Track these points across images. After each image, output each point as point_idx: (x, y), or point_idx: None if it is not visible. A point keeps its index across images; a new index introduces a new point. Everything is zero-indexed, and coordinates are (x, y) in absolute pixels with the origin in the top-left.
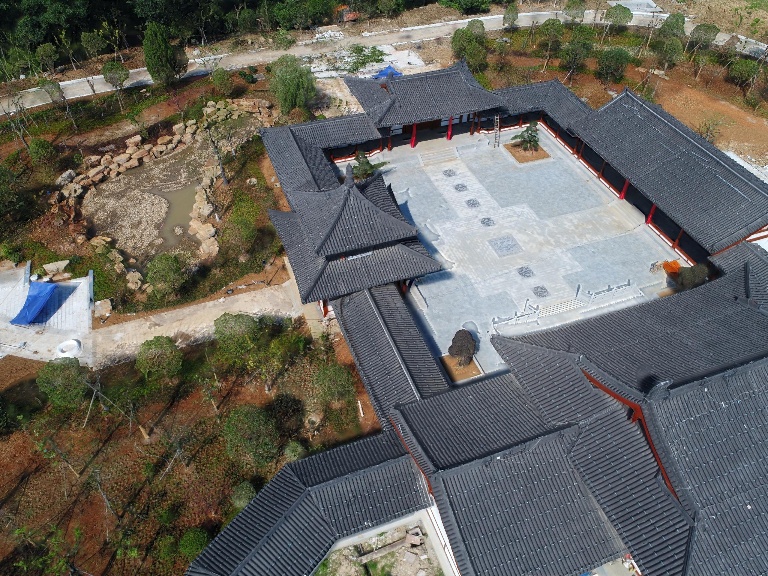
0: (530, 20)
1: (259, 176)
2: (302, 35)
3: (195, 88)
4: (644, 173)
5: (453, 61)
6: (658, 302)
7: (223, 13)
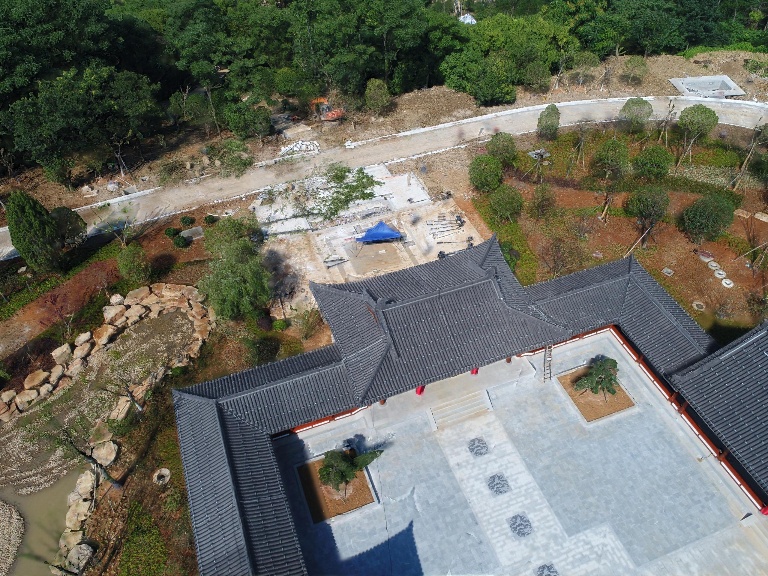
0: (571, 114)
1: (174, 465)
2: (262, 149)
3: (99, 263)
4: None
5: (471, 195)
6: None
7: (160, 108)
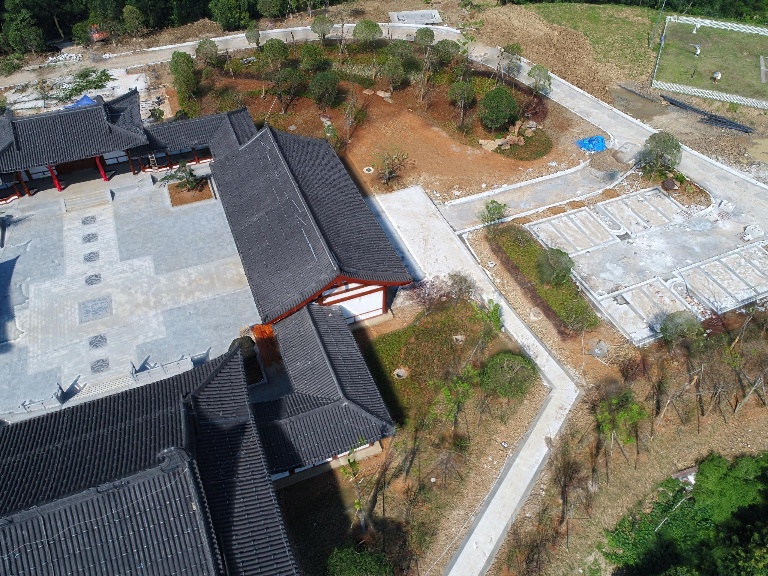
0: None
1: None
2: (35, 59)
3: None
4: (247, 224)
5: None
6: (107, 399)
7: None
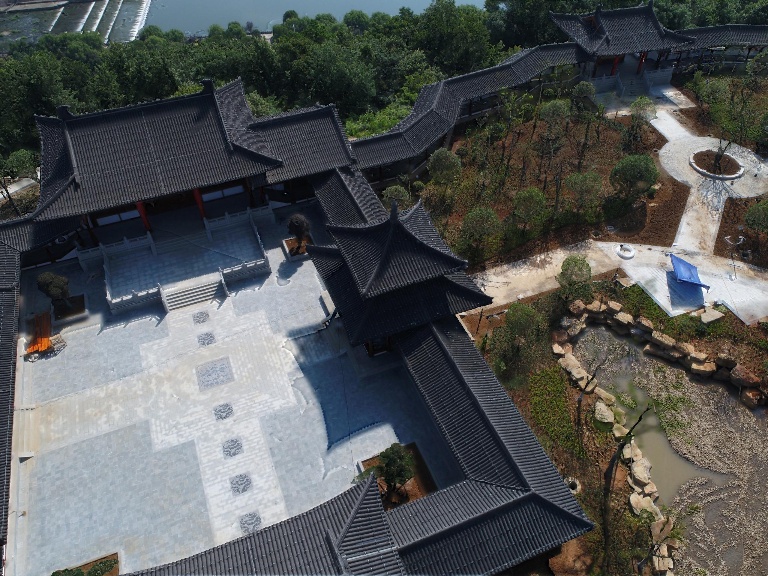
0: None
1: None
2: None
3: None
4: None
5: None
6: (138, 197)
7: None
